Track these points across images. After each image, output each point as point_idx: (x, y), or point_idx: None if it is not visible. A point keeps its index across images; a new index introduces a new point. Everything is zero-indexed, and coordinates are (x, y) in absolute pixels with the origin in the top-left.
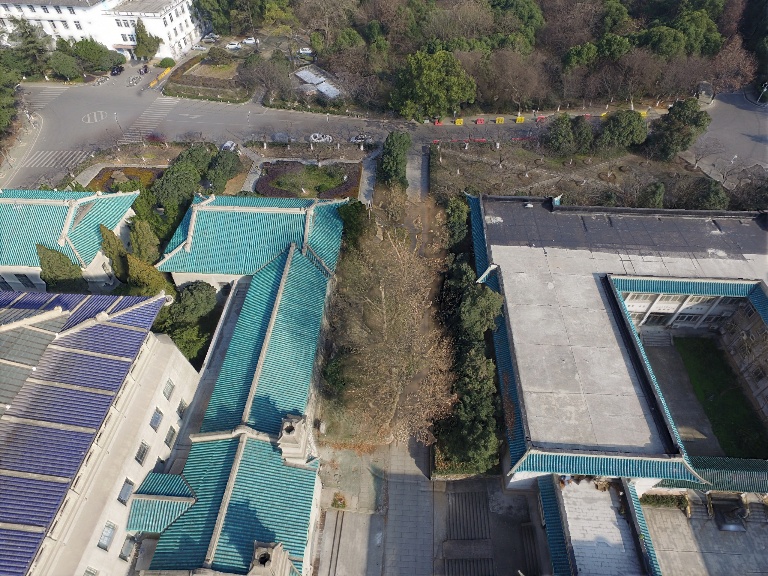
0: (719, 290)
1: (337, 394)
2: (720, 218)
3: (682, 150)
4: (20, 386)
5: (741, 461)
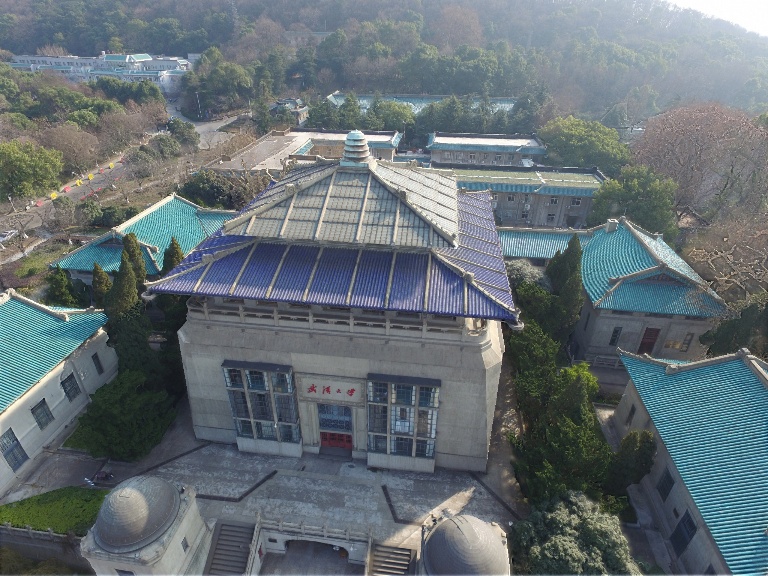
0: (309, 146)
1: None
2: (266, 139)
3: (198, 143)
4: None
5: None
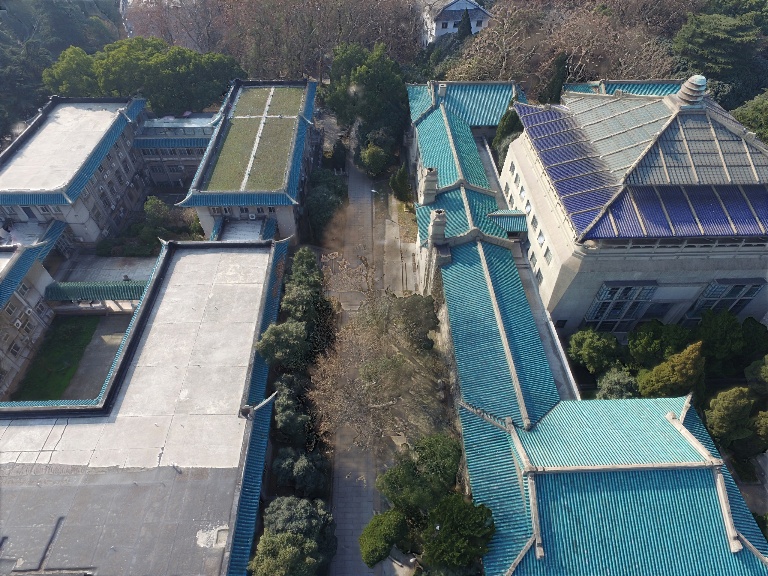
0: None
1: (427, 353)
2: None
3: None
4: (597, 149)
5: (101, 297)
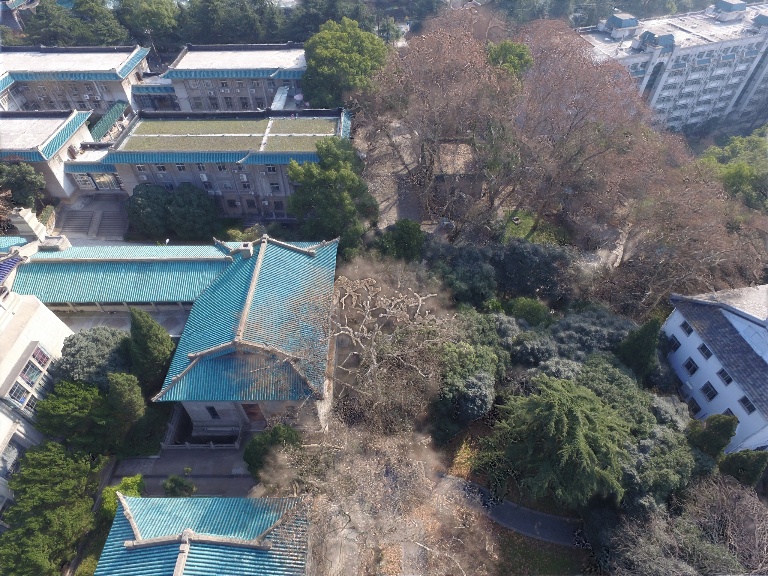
0: (2, 86)
1: None
2: None
3: None
4: None
5: None
